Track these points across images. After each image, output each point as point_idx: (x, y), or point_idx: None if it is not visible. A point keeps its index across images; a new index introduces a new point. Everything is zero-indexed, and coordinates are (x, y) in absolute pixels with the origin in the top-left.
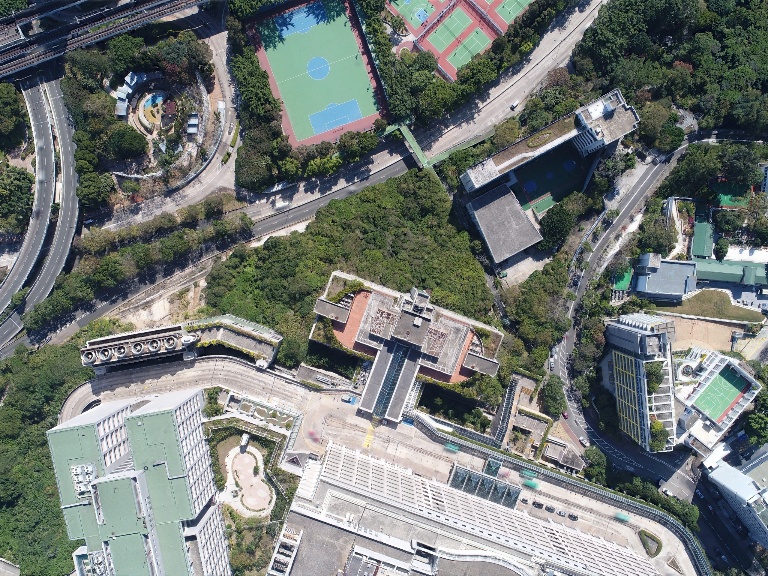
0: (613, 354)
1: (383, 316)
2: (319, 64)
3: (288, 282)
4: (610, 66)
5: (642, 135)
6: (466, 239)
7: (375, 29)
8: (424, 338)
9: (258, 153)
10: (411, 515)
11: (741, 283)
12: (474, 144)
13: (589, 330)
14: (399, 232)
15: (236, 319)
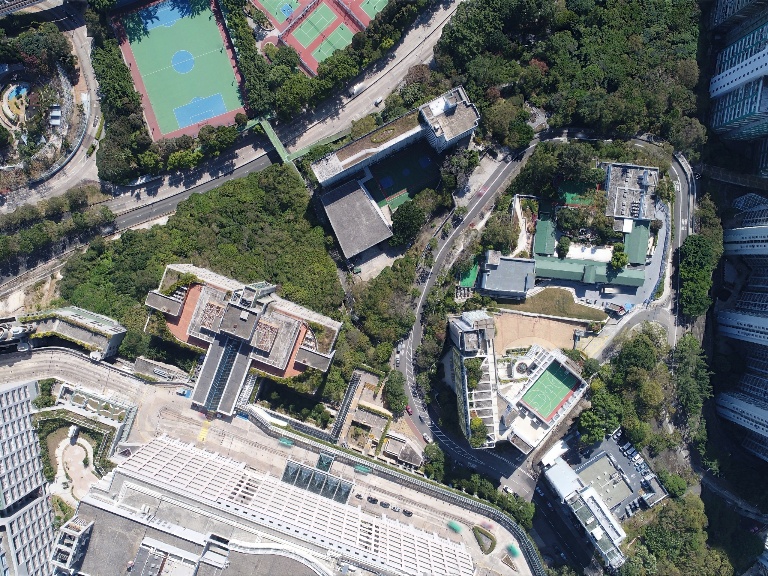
0: (453, 351)
1: (213, 309)
2: (184, 58)
3: (137, 275)
4: (468, 63)
5: (493, 132)
6: (320, 234)
7: (236, 23)
8: (251, 332)
9: (118, 146)
10: (207, 507)
11: (582, 281)
12: (335, 140)
13: (431, 326)
14: (256, 227)
15: (78, 311)
